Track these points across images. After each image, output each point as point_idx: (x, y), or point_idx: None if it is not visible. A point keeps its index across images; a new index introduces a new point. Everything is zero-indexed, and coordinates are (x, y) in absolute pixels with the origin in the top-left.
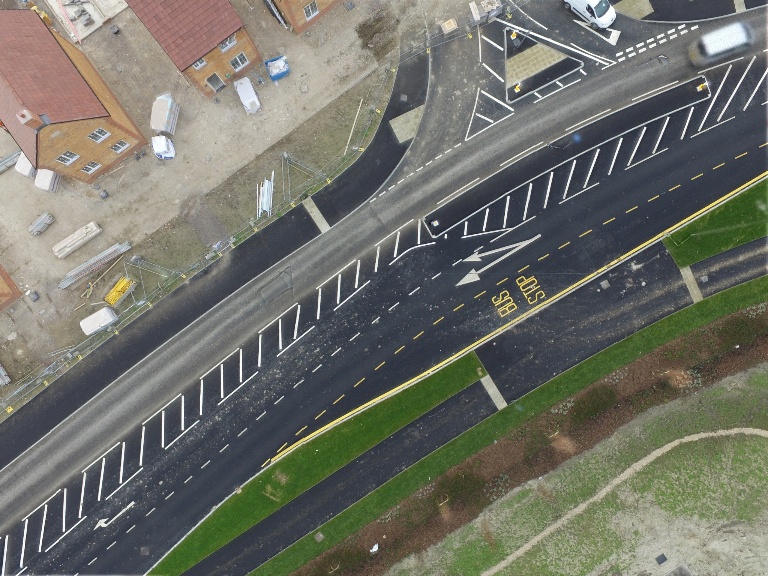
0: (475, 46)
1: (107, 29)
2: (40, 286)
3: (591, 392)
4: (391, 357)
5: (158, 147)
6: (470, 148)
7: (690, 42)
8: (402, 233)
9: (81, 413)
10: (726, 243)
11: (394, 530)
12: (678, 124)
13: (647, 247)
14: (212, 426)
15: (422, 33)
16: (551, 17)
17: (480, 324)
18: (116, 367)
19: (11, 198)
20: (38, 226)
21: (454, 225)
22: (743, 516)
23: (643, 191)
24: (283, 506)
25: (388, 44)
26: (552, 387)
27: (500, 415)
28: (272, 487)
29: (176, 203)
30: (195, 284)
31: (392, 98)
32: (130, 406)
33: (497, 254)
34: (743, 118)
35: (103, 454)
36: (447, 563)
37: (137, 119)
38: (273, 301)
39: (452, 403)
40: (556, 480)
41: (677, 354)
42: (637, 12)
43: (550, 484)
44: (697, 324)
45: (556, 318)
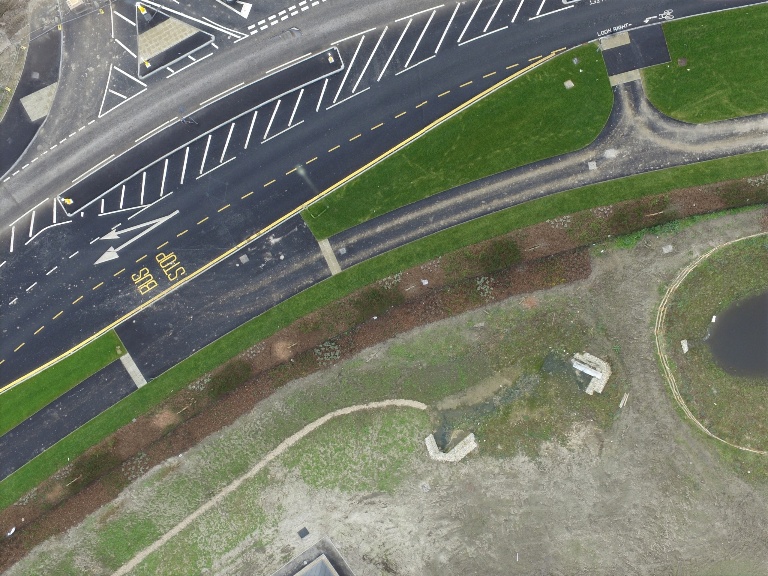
0: (108, 22)
1: None
2: None
3: (228, 367)
4: (31, 338)
5: None
6: (104, 125)
7: (322, 14)
8: (37, 212)
9: None
10: (362, 214)
11: (32, 512)
12: (313, 96)
13: (285, 220)
14: None
15: (54, 10)
16: None
17: (120, 302)
18: None
19: None
20: None
21: (89, 203)
22: (384, 487)
23: (280, 164)
24: None
25: (20, 21)
26: (190, 363)
27: (139, 393)
28: None
29: None
30: None
31: (23, 76)
32: None
33: (135, 231)
34: (377, 89)
35: None
36: (92, 544)
37: None
38: None
39: (91, 382)
40: (197, 457)
41: (310, 326)
42: None
43: (191, 461)
44: (334, 296)
45: (195, 294)
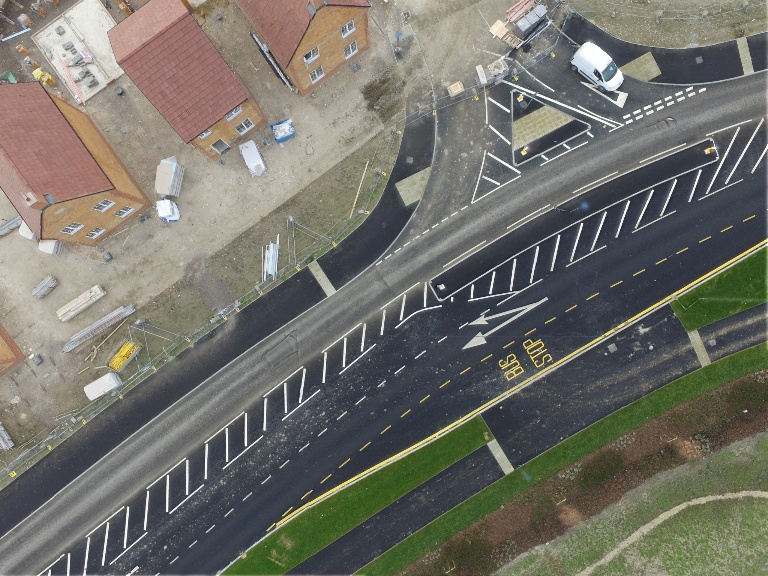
0: (481, 108)
1: (111, 90)
2: (44, 349)
3: (598, 457)
4: (397, 421)
5: (163, 211)
6: (476, 211)
7: (698, 104)
8: (408, 296)
9: (85, 477)
10: (734, 307)
11: None
12: (686, 187)
13: (655, 310)
14: (217, 490)
15: (428, 95)
16: (558, 79)
17: (487, 387)
18: (120, 431)
19: (15, 260)
20: (42, 290)
21: (460, 288)
22: None
23: (650, 254)
24: (288, 571)
25: (394, 106)
26: (559, 452)
27: (507, 480)
28: (277, 552)
29: (181, 265)
30: (200, 348)
31: (398, 160)
32: (134, 470)
33: (504, 317)
34: (751, 181)
35: (107, 519)
36: None
37: (141, 181)
38: (278, 365)
39: (458, 467)
40: (563, 545)
41: (685, 419)
42: (644, 74)
43: (557, 549)
44: (705, 388)
45: (563, 382)
